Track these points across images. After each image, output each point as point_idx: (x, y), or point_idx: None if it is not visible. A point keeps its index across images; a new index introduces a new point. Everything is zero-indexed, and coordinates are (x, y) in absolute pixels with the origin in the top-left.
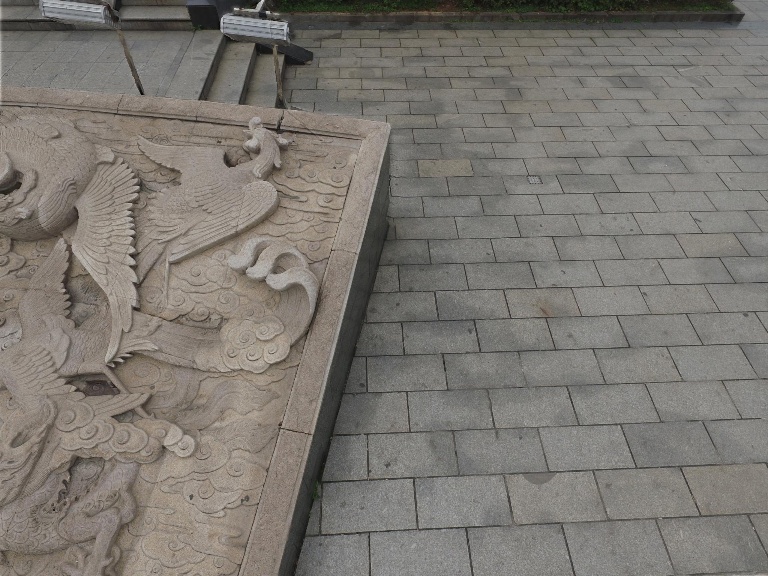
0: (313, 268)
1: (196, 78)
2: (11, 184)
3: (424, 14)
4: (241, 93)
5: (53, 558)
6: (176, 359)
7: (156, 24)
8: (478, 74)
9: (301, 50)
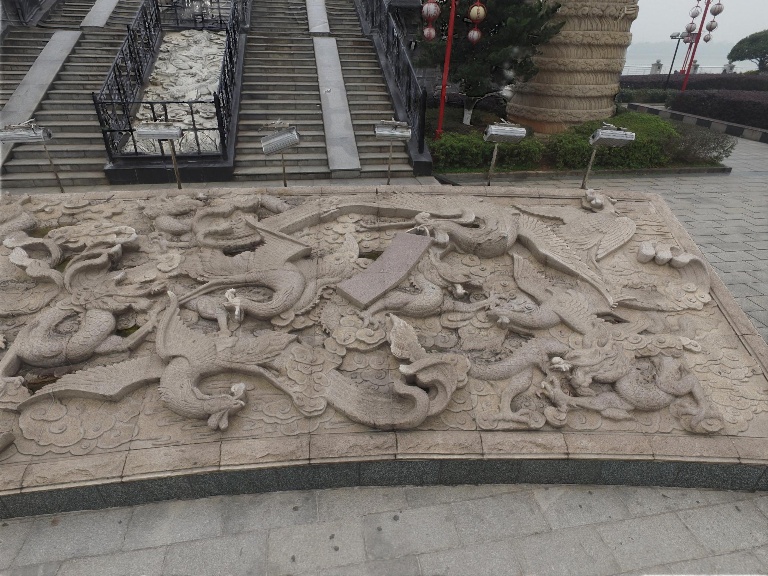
0: None
1: None
2: (472, 224)
3: (533, 172)
4: None
5: (662, 413)
6: (647, 304)
7: None
8: None
9: None
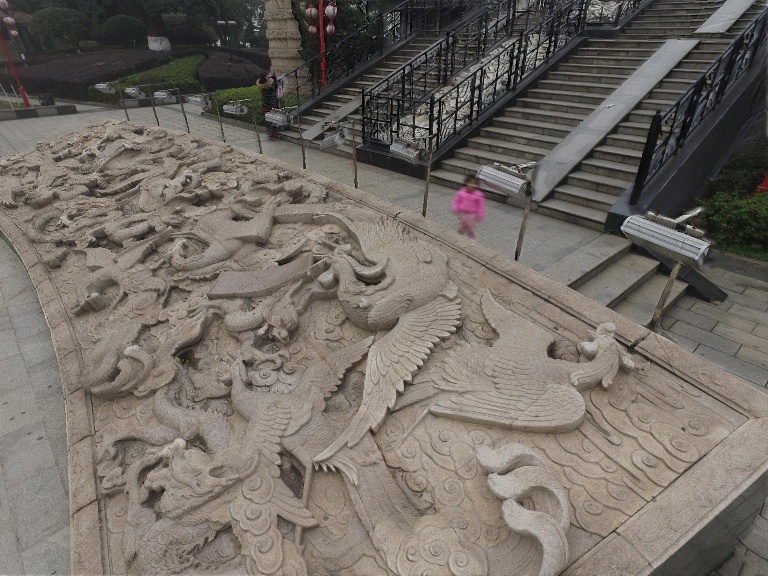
0: (574, 534)
1: (577, 269)
2: (375, 280)
3: None
4: (615, 298)
5: None
6: (362, 509)
7: (571, 218)
8: None
9: (713, 287)
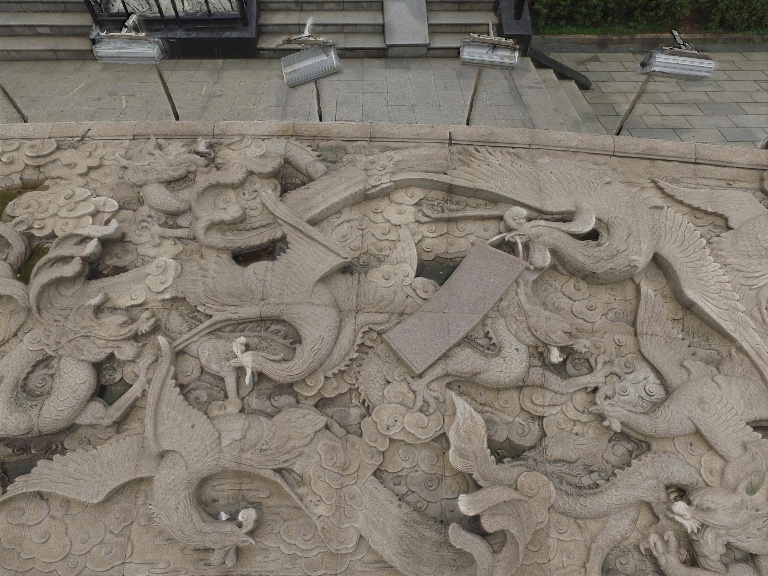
0: None
1: (548, 108)
2: None
3: (669, 36)
4: None
5: None
6: None
7: None
8: (762, 99)
9: (580, 75)
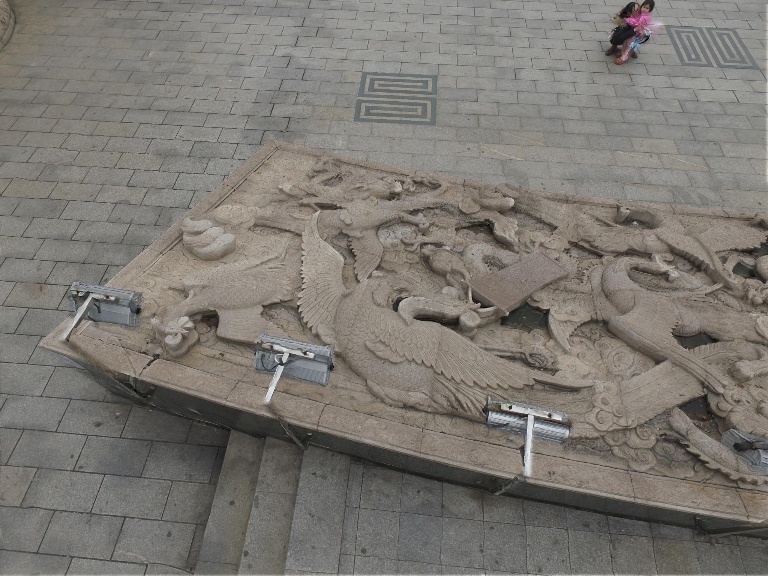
0: None
1: None
2: None
3: None
4: None
5: None
6: None
7: None
8: None
9: None
